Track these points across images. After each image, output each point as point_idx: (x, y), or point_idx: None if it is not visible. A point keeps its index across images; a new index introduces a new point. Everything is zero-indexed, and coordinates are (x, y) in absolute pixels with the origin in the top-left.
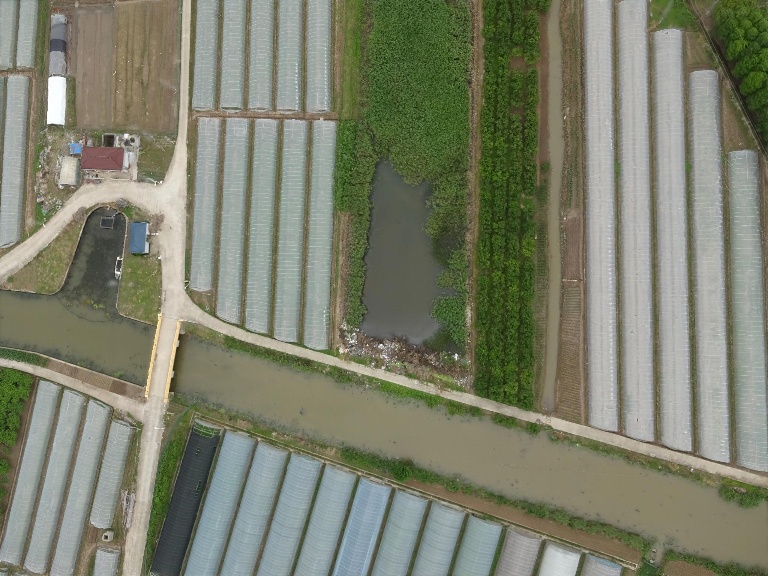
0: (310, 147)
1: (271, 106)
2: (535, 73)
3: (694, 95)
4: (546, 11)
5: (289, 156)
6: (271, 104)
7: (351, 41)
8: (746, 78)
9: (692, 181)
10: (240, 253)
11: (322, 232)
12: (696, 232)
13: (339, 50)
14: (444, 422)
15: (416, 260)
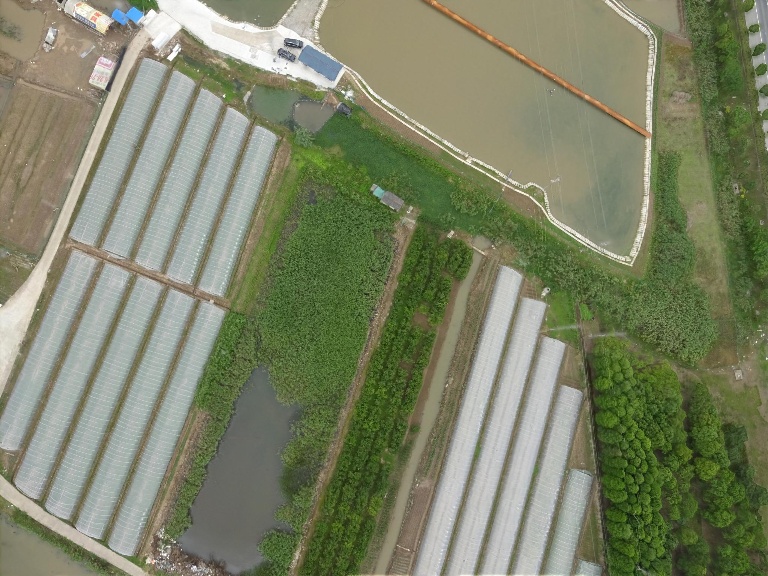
0: (189, 327)
1: (161, 267)
2: (433, 337)
3: (559, 407)
4: (461, 280)
5: (162, 331)
6: (162, 265)
7: (269, 233)
8: (603, 414)
9: (535, 485)
10: (68, 419)
11: (171, 426)
12: (525, 535)
13: (254, 237)
14: None
15: (261, 483)
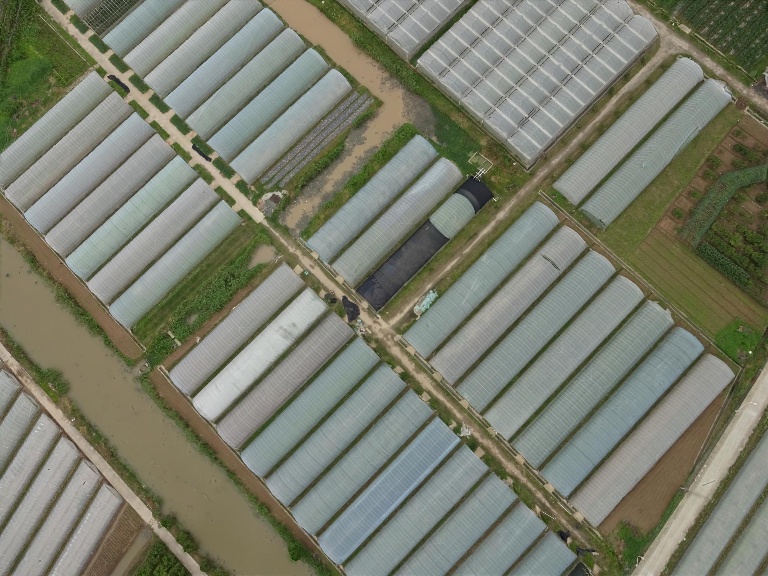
0: None
1: None
2: None
3: None
4: None
5: None
6: None
7: None
8: None
9: None
10: None
11: None
12: None
13: None
14: (239, 571)
15: None
